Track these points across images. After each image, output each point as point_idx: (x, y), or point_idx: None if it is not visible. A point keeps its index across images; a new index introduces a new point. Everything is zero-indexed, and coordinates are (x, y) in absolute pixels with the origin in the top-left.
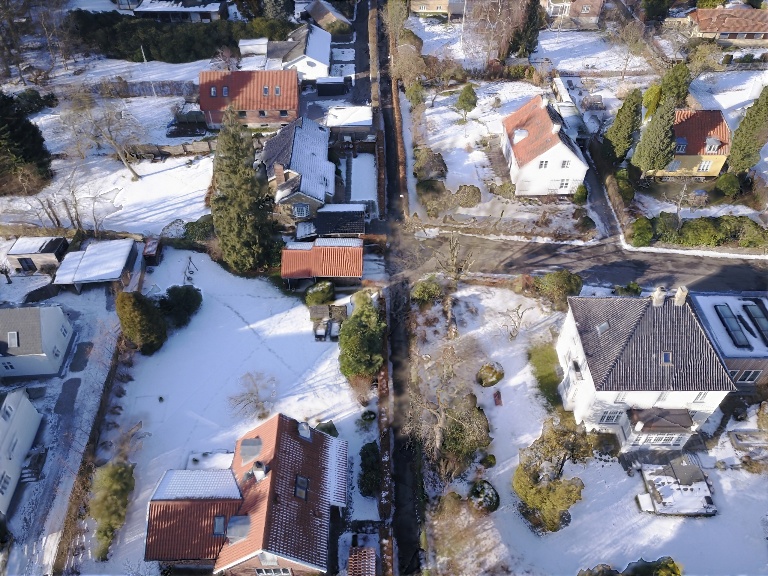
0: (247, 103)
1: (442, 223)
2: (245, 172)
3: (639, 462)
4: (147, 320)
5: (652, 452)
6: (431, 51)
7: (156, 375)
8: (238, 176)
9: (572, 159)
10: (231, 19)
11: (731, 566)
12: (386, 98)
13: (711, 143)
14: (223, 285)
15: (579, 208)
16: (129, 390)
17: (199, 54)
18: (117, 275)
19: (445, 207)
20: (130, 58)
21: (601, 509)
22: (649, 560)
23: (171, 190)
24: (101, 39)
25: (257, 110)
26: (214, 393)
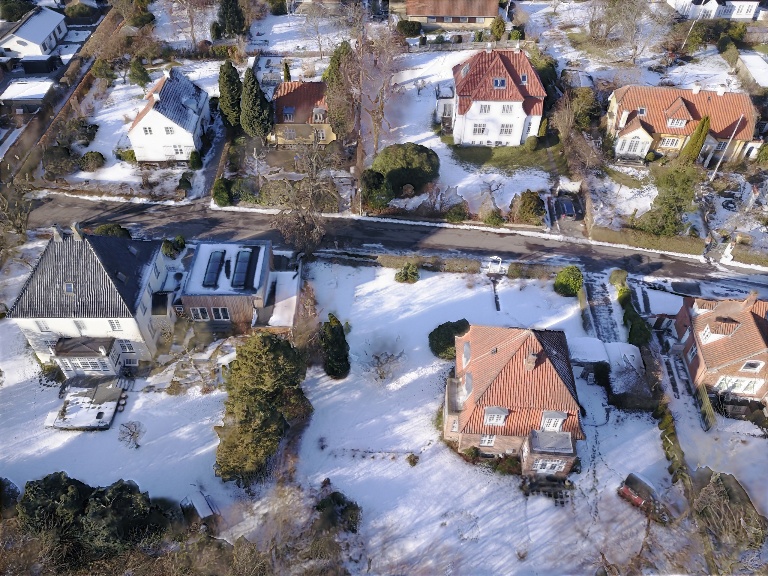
0: None
1: (55, 186)
2: None
3: (70, 386)
4: None
5: (88, 377)
6: (161, 33)
7: None
8: None
9: (173, 126)
10: None
11: (91, 470)
12: None
13: (314, 112)
14: None
15: (187, 172)
16: None
17: None
18: None
19: (62, 171)
20: None
21: (13, 425)
22: (24, 466)
23: None
24: None
25: None
26: None
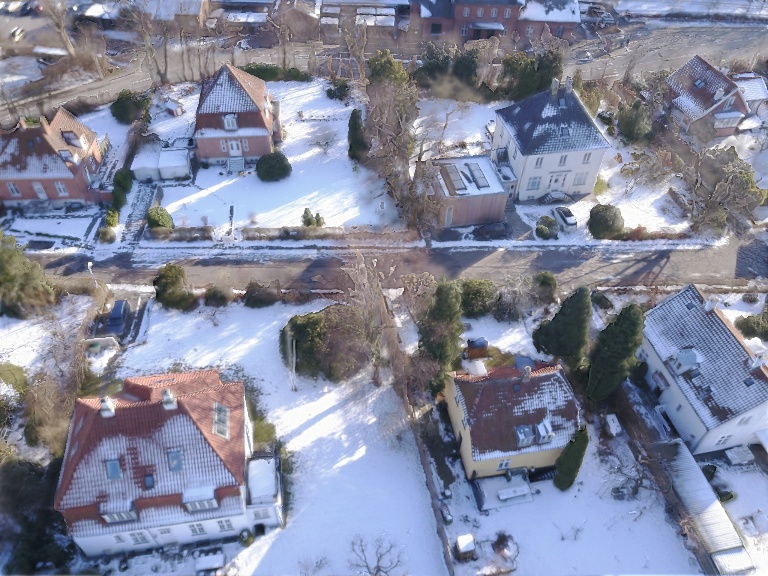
0: None
1: None
2: None
3: None
4: None
5: None
6: None
7: None
8: None
9: None
10: None
11: None
12: None
13: None
14: None
15: None
16: None
17: None
18: None
19: None
20: None
21: None
22: None
23: None
24: None
25: None
26: None
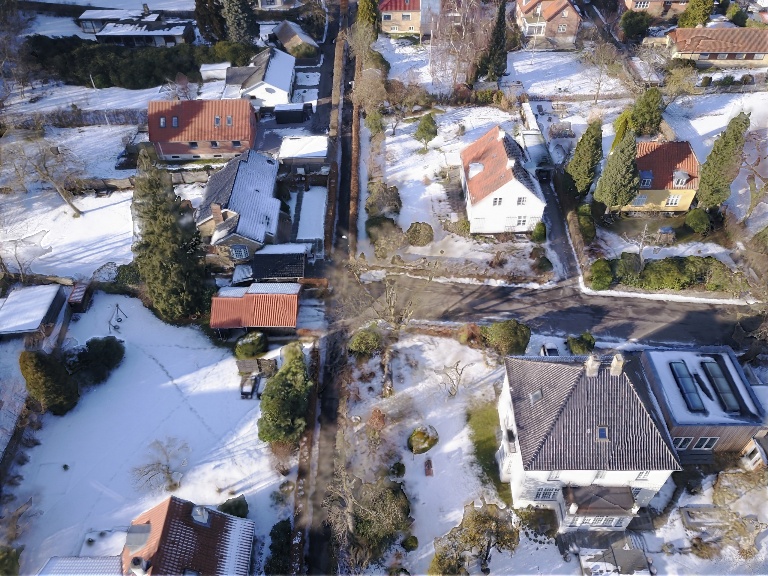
0: (198, 134)
1: (390, 264)
2: (164, 218)
3: (577, 545)
4: (53, 381)
5: (592, 533)
6: (399, 74)
7: (65, 438)
8: (157, 223)
9: (528, 196)
10: (194, 43)
11: None
12: (347, 125)
13: (678, 177)
14: (151, 334)
15: (537, 247)
16: (34, 456)
17: (160, 80)
18: (35, 326)
19: (394, 246)
20: (89, 84)
21: None
22: None
23: (112, 227)
24: (59, 65)
25: (208, 141)
26: (124, 459)
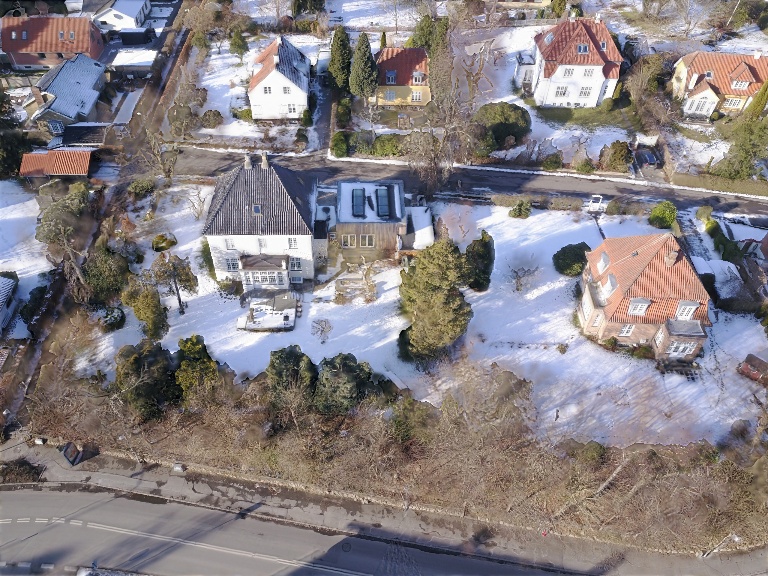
0: (44, 46)
1: (182, 140)
2: None
3: (251, 297)
4: None
5: (264, 291)
6: None
7: None
8: None
9: (291, 86)
10: None
11: None
12: (182, 47)
13: (415, 75)
14: None
15: (301, 128)
16: None
17: (29, 10)
18: None
19: (188, 127)
20: None
21: (208, 328)
22: (228, 359)
23: None
24: None
25: (54, 52)
26: None
